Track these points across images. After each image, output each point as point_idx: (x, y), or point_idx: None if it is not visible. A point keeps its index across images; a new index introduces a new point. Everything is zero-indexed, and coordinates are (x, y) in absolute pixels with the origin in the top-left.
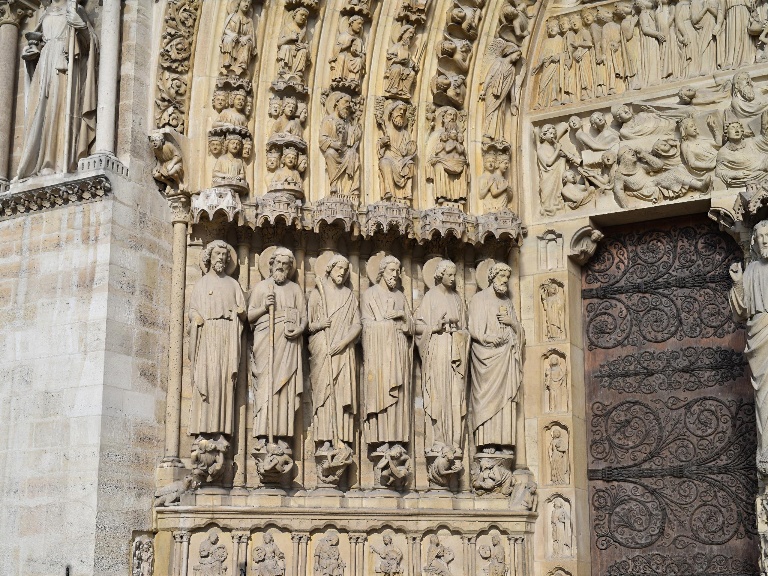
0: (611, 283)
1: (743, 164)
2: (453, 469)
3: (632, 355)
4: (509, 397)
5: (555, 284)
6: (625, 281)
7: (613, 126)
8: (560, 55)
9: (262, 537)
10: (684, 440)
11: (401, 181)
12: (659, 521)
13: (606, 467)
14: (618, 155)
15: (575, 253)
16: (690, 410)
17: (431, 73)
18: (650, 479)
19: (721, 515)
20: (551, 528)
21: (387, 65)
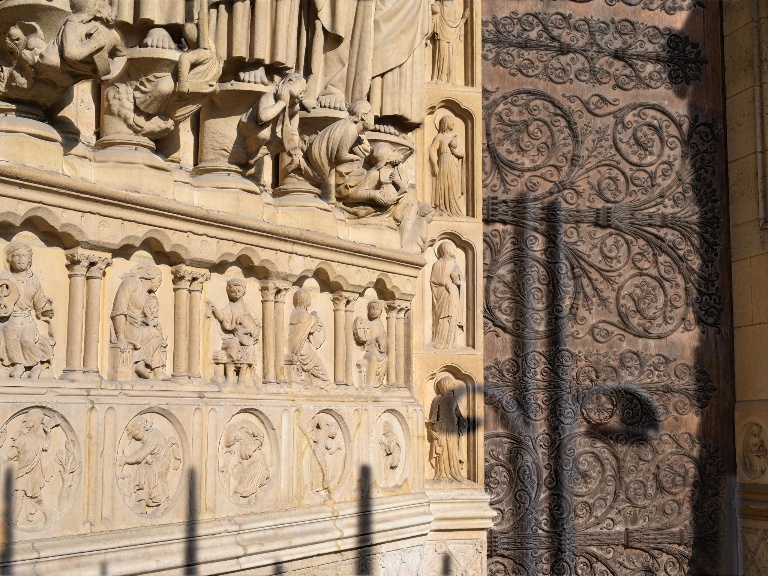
0: None
1: None
2: (358, 152)
3: (535, 14)
4: (426, 31)
5: None
6: None
7: None
8: None
9: (2, 252)
10: (612, 167)
11: None
12: (570, 295)
13: (490, 197)
14: None
15: None
16: (623, 120)
17: None
18: (557, 225)
19: (662, 292)
20: (430, 294)
21: None
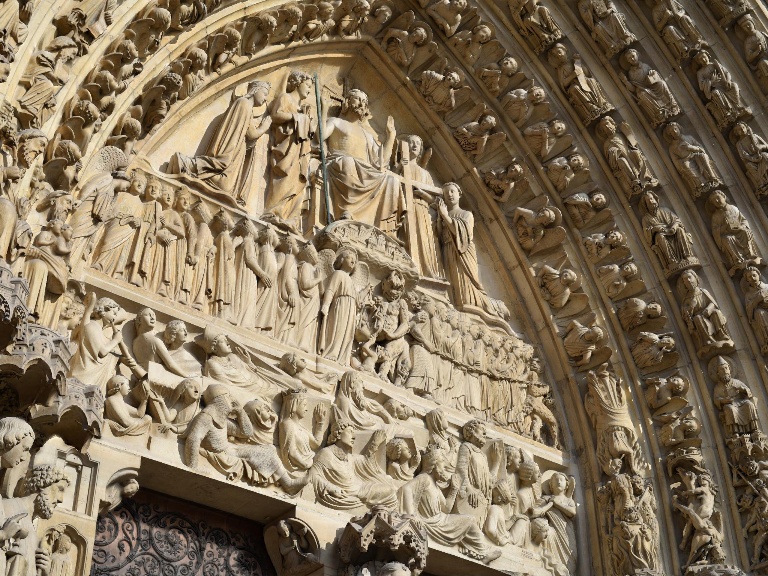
0: (110, 567)
1: (345, 480)
2: None
3: None
4: None
5: (68, 536)
6: (128, 571)
7: (189, 351)
8: (142, 221)
9: None
10: None
11: (13, 251)
12: None
13: None
14: (213, 392)
15: (110, 500)
16: None
17: (52, 126)
18: None
19: None
20: None
21: (33, 68)
